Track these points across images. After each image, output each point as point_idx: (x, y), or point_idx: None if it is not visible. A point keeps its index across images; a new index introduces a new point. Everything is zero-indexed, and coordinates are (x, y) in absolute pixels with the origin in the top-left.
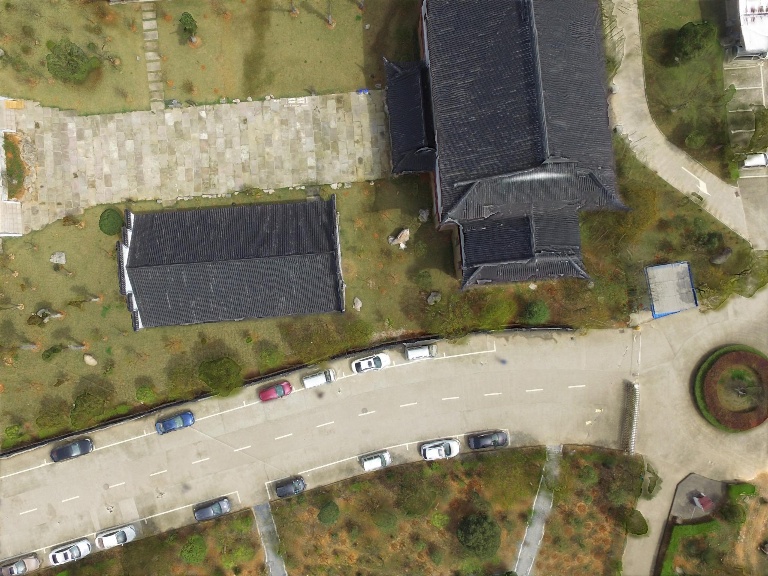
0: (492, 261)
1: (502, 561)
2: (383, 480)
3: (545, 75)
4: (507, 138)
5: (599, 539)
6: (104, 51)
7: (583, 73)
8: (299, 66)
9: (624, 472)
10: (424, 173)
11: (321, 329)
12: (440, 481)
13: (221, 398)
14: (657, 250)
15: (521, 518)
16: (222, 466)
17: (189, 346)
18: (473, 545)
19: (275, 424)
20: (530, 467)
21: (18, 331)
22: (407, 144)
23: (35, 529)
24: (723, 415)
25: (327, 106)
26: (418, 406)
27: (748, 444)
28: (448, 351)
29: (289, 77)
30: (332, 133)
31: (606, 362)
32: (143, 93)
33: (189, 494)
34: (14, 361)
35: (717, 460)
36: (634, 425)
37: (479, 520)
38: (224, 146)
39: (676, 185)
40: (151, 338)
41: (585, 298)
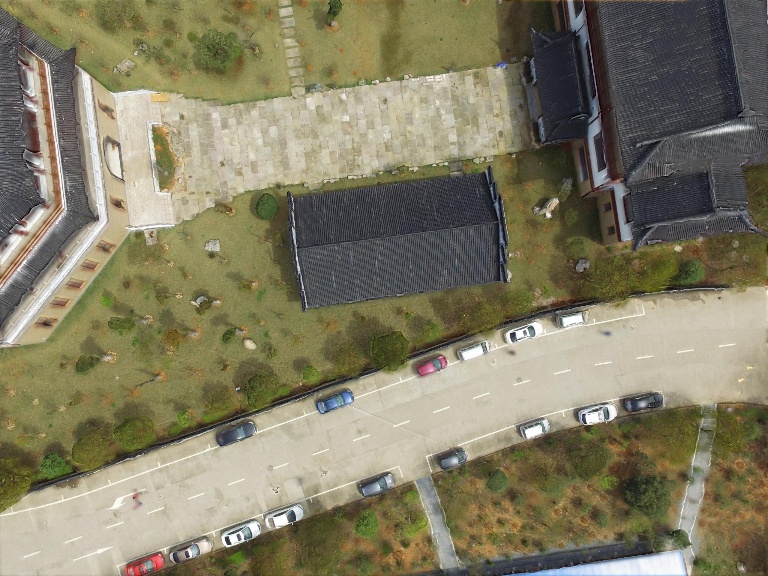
0: (667, 220)
1: (665, 521)
2: (543, 447)
3: None
4: (694, 94)
5: (759, 495)
6: (243, 40)
7: (759, 27)
8: (435, 44)
9: None
10: (565, 143)
11: (473, 302)
12: (599, 445)
13: (377, 375)
14: None
15: (681, 478)
16: (383, 442)
17: (344, 325)
18: (645, 504)
19: (432, 398)
20: None
21: (178, 319)
22: (560, 112)
23: (204, 513)
24: None
25: (464, 82)
26: (572, 373)
27: None
28: (598, 317)
29: (426, 56)
30: (471, 108)
31: (754, 320)
32: (284, 79)
33: (352, 471)
34: (175, 349)
35: None
36: None
37: (648, 480)
38: (366, 127)
39: None
40: (307, 320)
41: (731, 257)
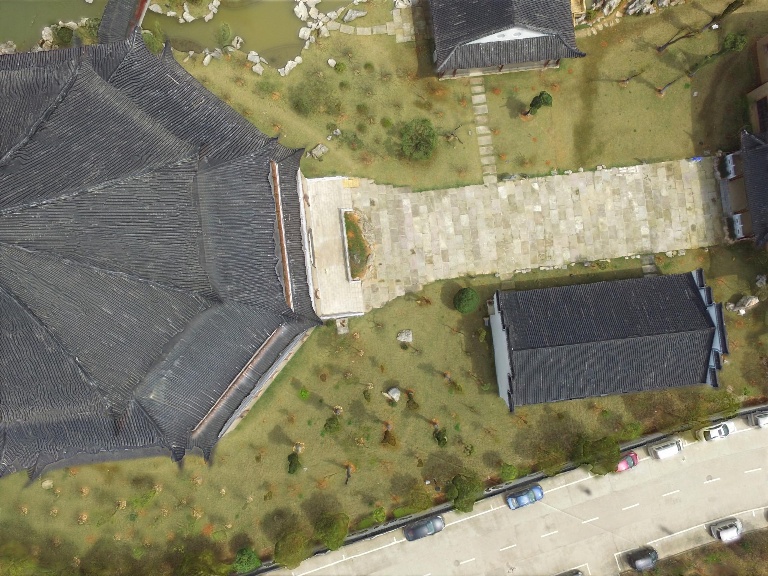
0: None
1: None
2: (735, 548)
3: None
4: None
5: None
6: (437, 127)
7: None
8: (629, 135)
9: None
10: None
11: (664, 398)
12: None
13: None
14: None
15: None
16: (571, 539)
17: (535, 419)
18: None
19: (622, 494)
20: None
21: (368, 411)
22: None
23: None
24: None
25: (657, 174)
26: (763, 472)
27: None
28: None
29: (619, 147)
30: (664, 201)
31: None
32: (476, 167)
33: (540, 568)
34: (365, 441)
35: None
36: None
37: None
38: (558, 217)
39: None
40: (497, 413)
41: None
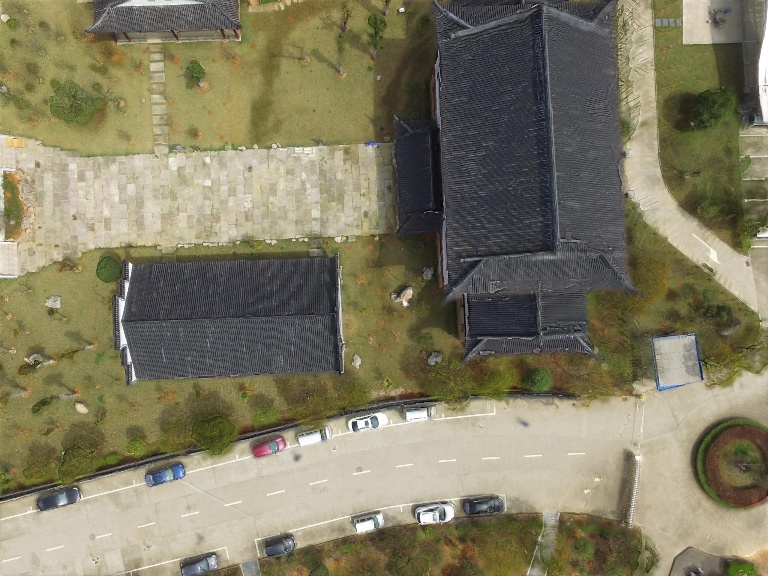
0: (496, 334)
1: None
2: (375, 542)
3: (559, 155)
4: (517, 217)
5: None
6: (109, 92)
7: (598, 151)
8: (307, 115)
9: (621, 544)
10: None
11: (318, 385)
12: (433, 545)
13: None
14: (664, 319)
15: None
16: (212, 521)
17: (183, 397)
18: None
19: (267, 480)
20: (526, 535)
21: (9, 375)
22: (414, 205)
23: None
24: (724, 490)
25: (334, 157)
26: (414, 467)
27: (748, 520)
28: (447, 412)
29: (297, 126)
30: (338, 185)
31: (607, 430)
32: (147, 136)
33: (177, 548)
34: (4, 406)
35: (716, 535)
36: (633, 497)
37: None
38: (227, 194)
39: (686, 252)
40: (145, 387)
41: (589, 364)
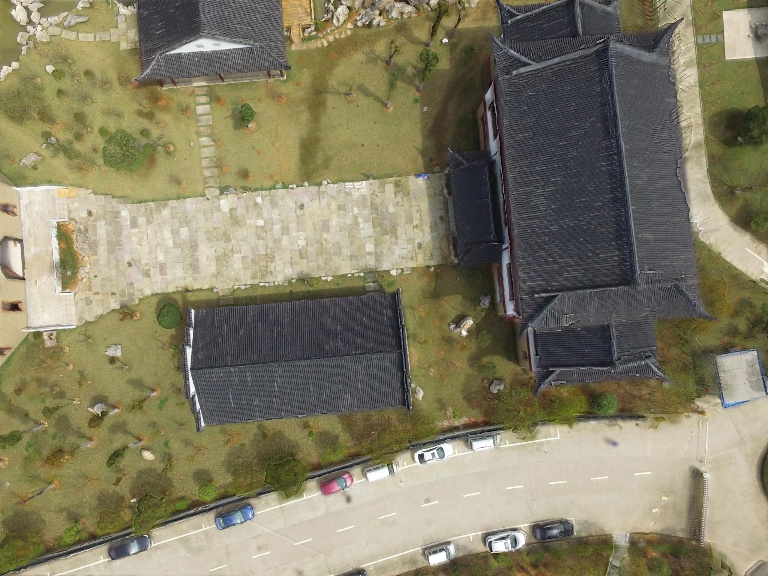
0: (569, 365)
1: None
2: (448, 573)
3: None
4: (592, 251)
5: None
6: (157, 137)
7: (666, 180)
8: (356, 150)
9: (692, 561)
10: None
11: (382, 419)
12: (505, 573)
13: None
14: (723, 334)
15: None
16: (283, 560)
17: (248, 438)
18: None
19: (336, 516)
20: (597, 557)
21: (74, 426)
22: (473, 237)
23: None
24: None
25: (385, 190)
26: (482, 496)
27: None
28: (511, 439)
29: (346, 161)
30: (390, 218)
31: (672, 448)
32: (198, 179)
33: None
34: (70, 457)
35: None
36: (703, 515)
37: None
38: (281, 232)
39: (740, 266)
40: (209, 431)
41: (650, 383)
